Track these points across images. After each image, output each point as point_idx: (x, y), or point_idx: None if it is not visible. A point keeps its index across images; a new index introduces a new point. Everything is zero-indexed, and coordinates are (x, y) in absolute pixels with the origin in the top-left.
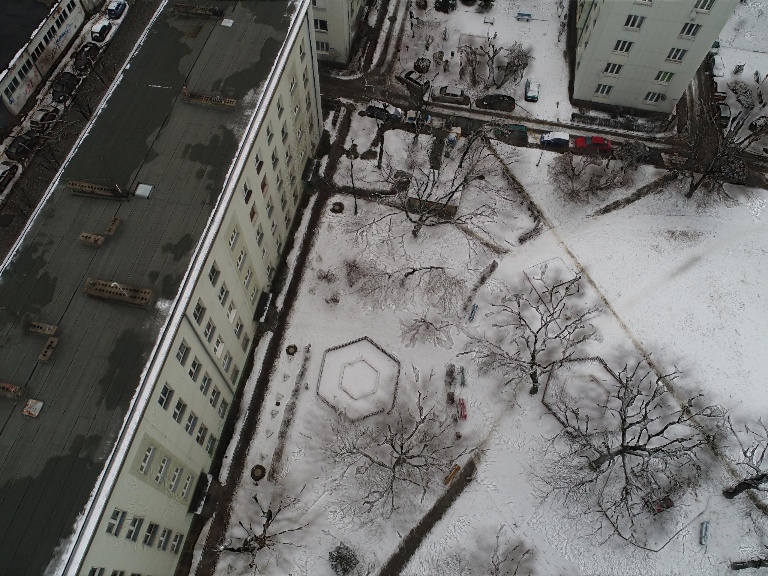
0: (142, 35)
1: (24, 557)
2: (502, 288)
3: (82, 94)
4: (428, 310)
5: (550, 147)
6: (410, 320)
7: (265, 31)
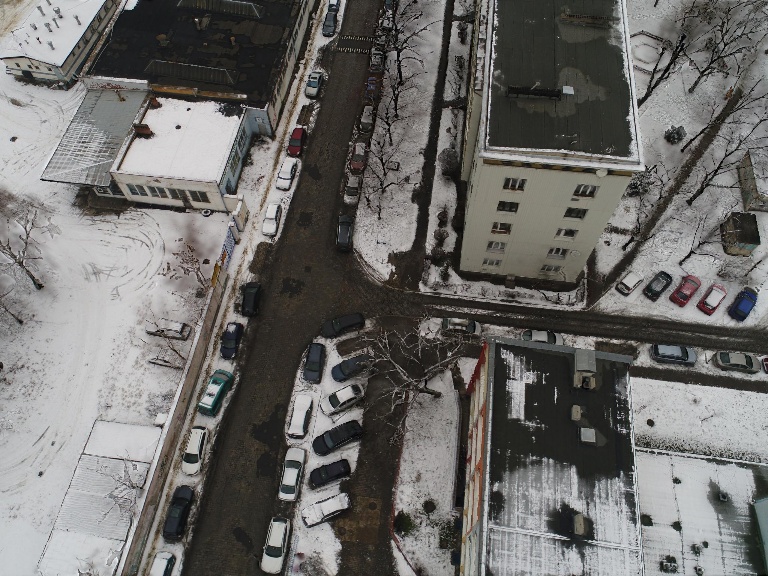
0: None
1: (599, 10)
2: (725, 2)
3: None
4: (678, 17)
5: None
6: (668, 23)
7: None
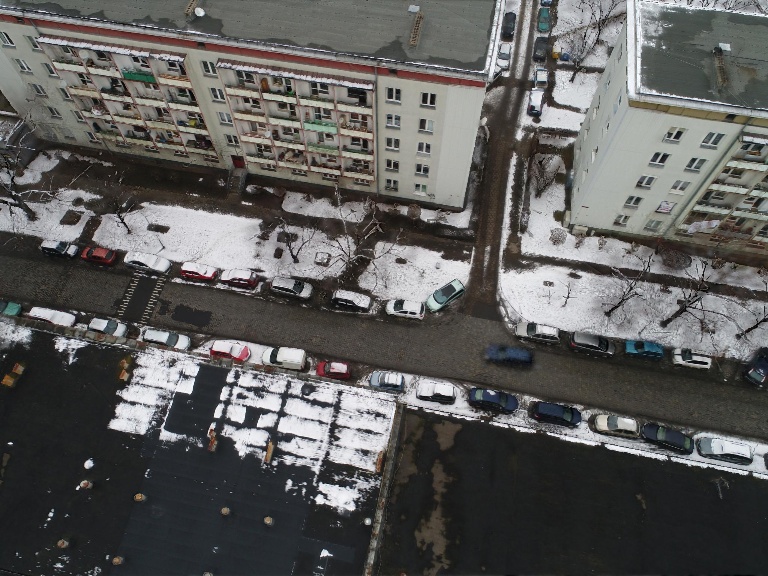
0: (761, 115)
1: None
2: None
3: (559, 393)
4: None
5: (552, 2)
6: None
7: (721, 24)
